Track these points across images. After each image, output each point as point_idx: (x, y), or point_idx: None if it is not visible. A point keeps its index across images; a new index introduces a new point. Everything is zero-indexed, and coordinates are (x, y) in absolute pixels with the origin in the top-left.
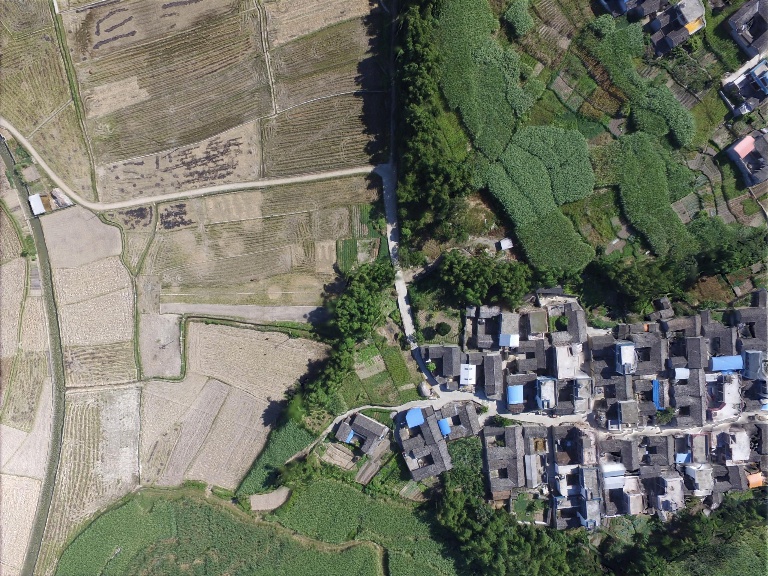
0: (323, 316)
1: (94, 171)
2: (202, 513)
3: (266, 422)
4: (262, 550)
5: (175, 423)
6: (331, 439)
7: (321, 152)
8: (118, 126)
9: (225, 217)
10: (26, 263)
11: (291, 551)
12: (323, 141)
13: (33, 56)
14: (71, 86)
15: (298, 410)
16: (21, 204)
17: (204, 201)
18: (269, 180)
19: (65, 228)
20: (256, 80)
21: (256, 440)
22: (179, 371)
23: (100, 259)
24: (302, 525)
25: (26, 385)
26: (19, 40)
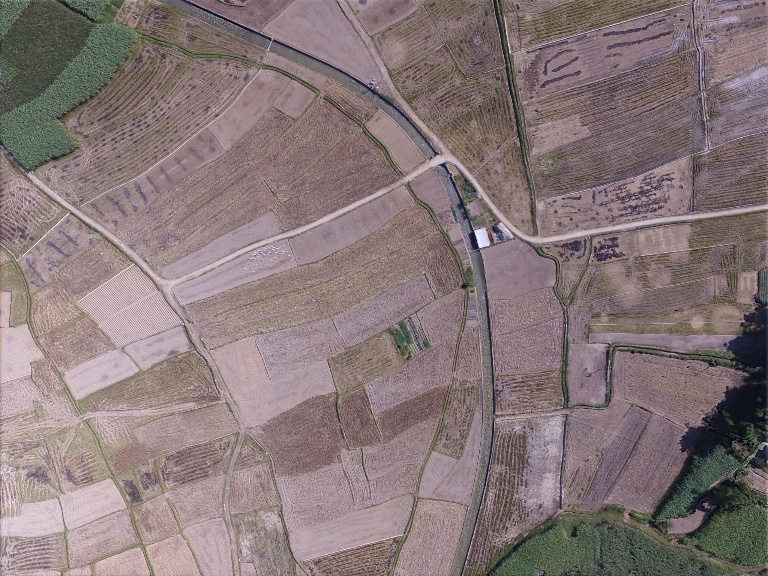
0: (742, 345)
1: (535, 206)
2: (625, 537)
3: (684, 448)
4: (685, 573)
5: (597, 449)
6: (755, 465)
7: (748, 187)
8: (559, 162)
9: (655, 249)
10: (466, 295)
11: (713, 574)
12: (750, 176)
13: (483, 95)
14: (519, 124)
15: (728, 437)
16: (464, 238)
17: (636, 234)
18: (699, 214)
19: (503, 261)
20: (691, 117)
21: (673, 465)
22: (603, 399)
23: (534, 290)
24: (722, 548)
25: (459, 413)
26: (471, 80)
